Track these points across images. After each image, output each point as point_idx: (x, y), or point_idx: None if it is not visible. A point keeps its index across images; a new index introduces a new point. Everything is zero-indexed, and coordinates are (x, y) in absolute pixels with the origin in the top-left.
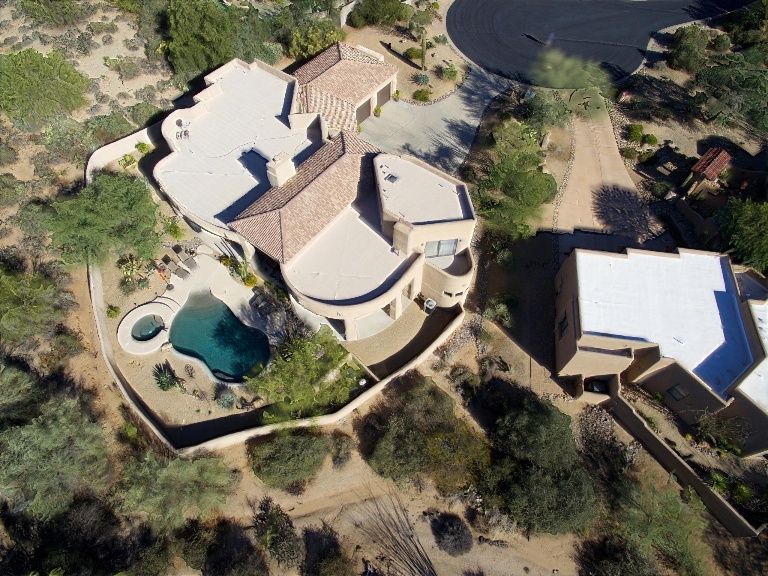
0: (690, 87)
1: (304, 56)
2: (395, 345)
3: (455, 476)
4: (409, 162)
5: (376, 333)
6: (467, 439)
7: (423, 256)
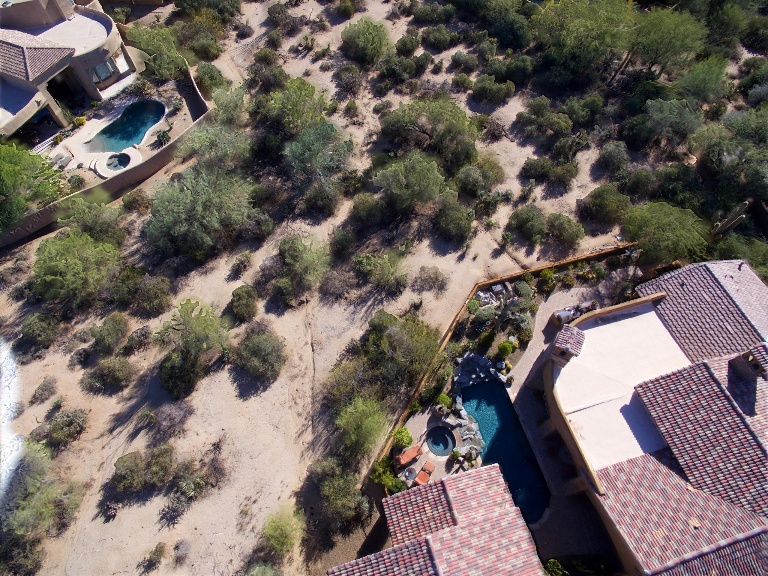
0: None
1: None
2: (141, 53)
3: (218, 34)
4: None
5: None
6: None
7: None
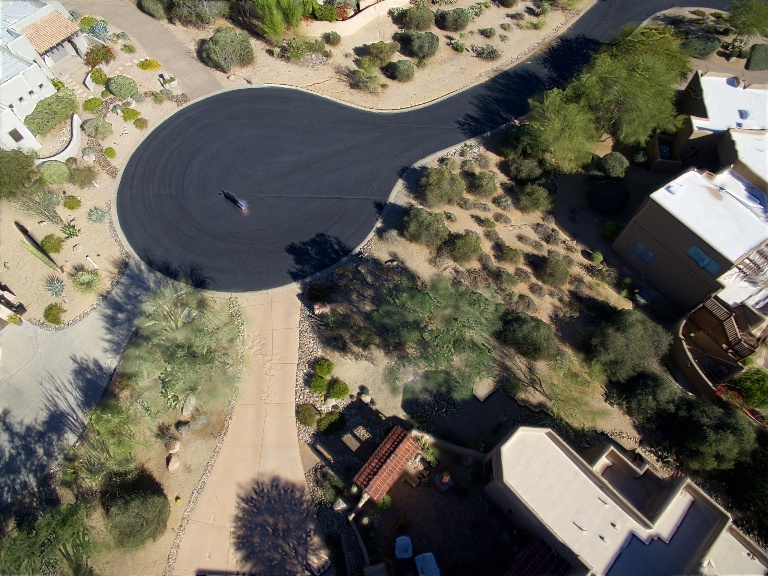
0: (423, 272)
1: None
2: None
3: None
4: None
5: None
6: None
7: None
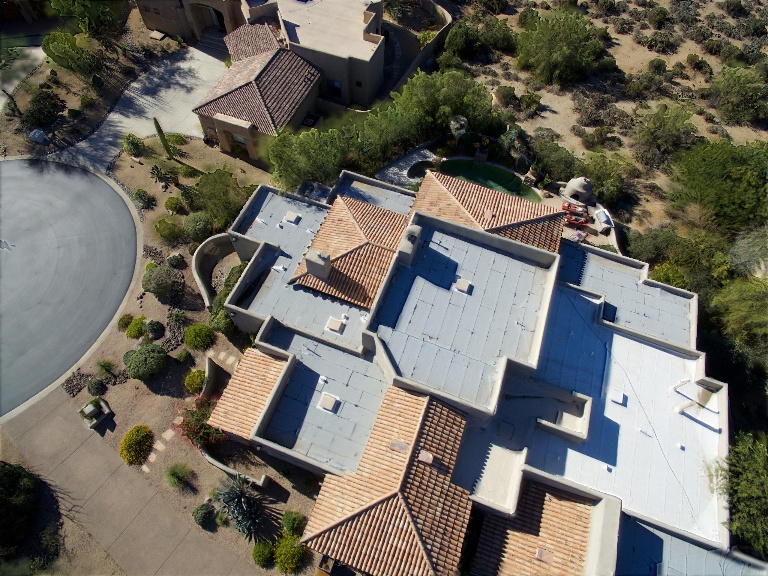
0: None
1: None
2: None
3: None
4: None
5: None
6: None
7: None
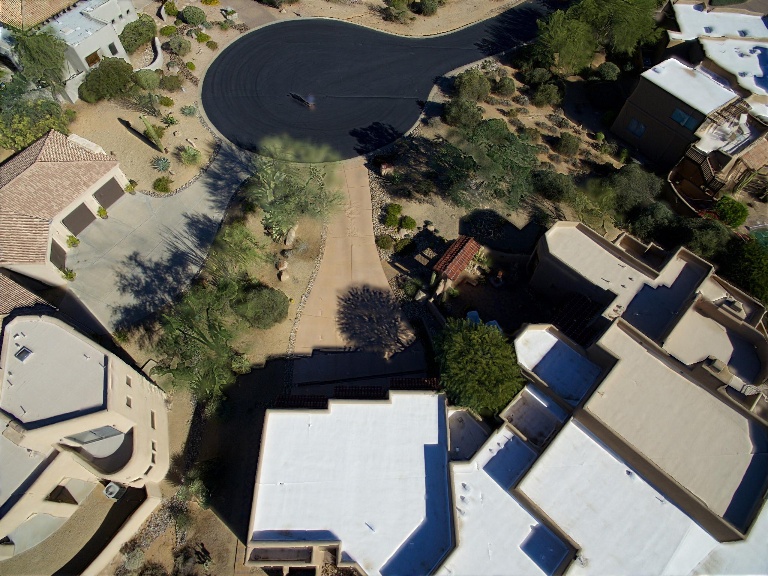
0: (464, 146)
1: (17, 148)
2: (63, 555)
3: None
4: (53, 325)
5: (40, 541)
6: None
7: (62, 455)
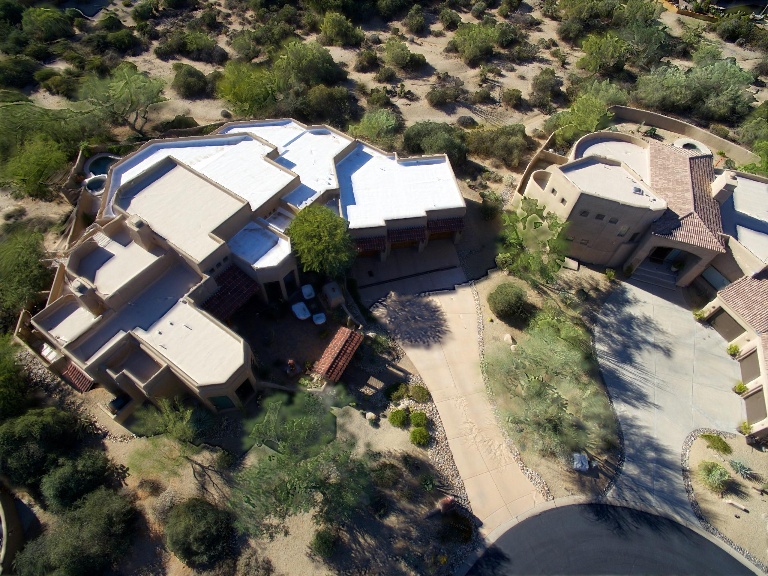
0: None
1: None
2: None
3: None
4: None
5: None
6: (481, 140)
7: None
